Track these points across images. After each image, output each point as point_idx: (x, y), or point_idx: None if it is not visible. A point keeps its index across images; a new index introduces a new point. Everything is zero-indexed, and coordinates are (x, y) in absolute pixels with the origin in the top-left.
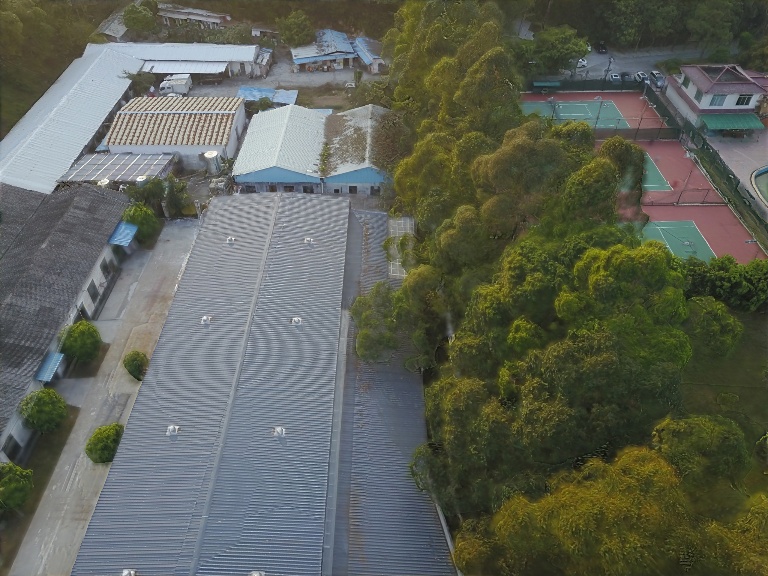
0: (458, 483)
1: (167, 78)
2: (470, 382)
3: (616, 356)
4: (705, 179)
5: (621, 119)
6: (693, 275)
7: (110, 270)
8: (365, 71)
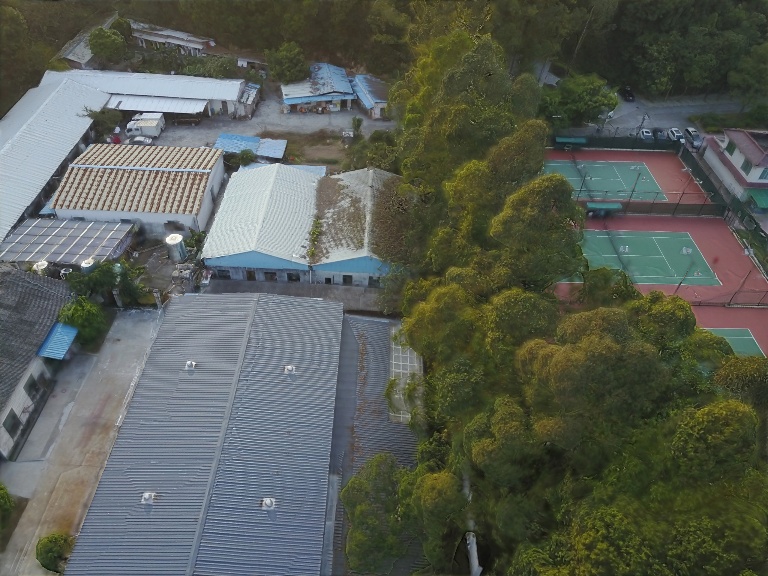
0: None
1: (136, 117)
2: None
3: None
4: (757, 271)
5: (660, 193)
6: None
7: (39, 386)
8: (365, 115)
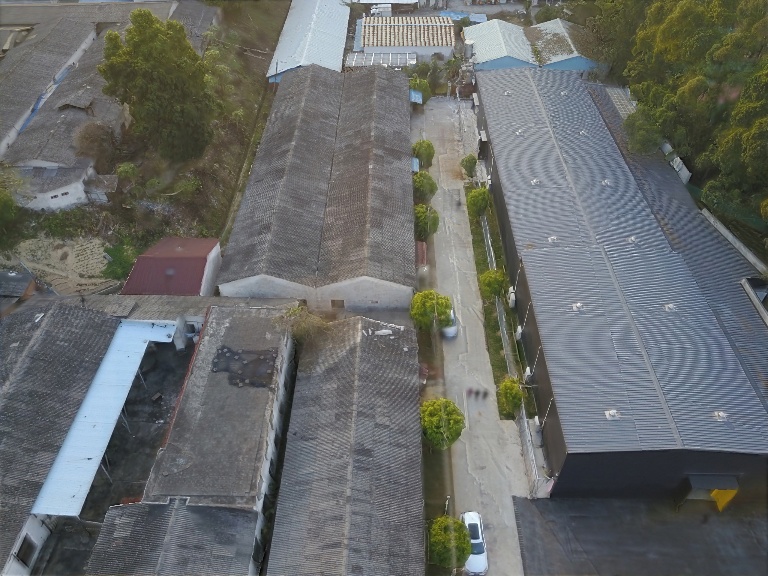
0: (739, 198)
1: (374, 7)
2: None
3: None
4: None
5: None
6: None
7: None
8: None
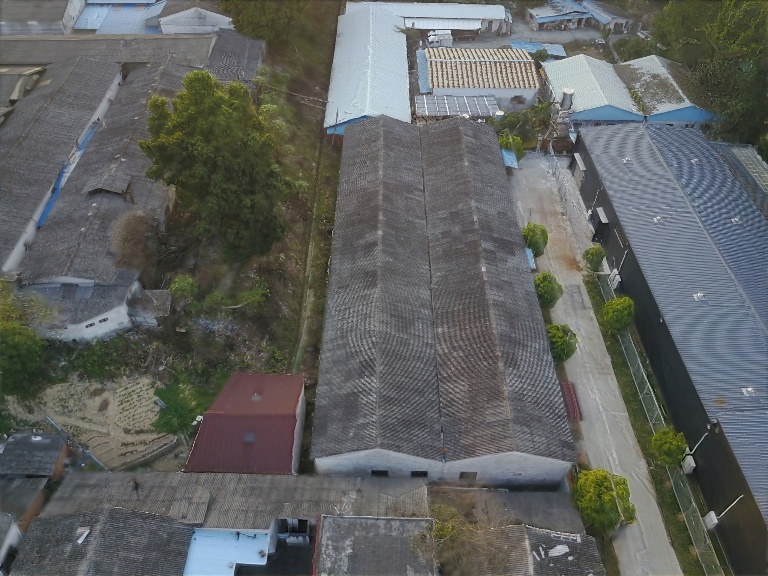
0: None
1: (432, 33)
2: None
3: None
4: None
5: None
6: None
7: None
8: (598, 30)
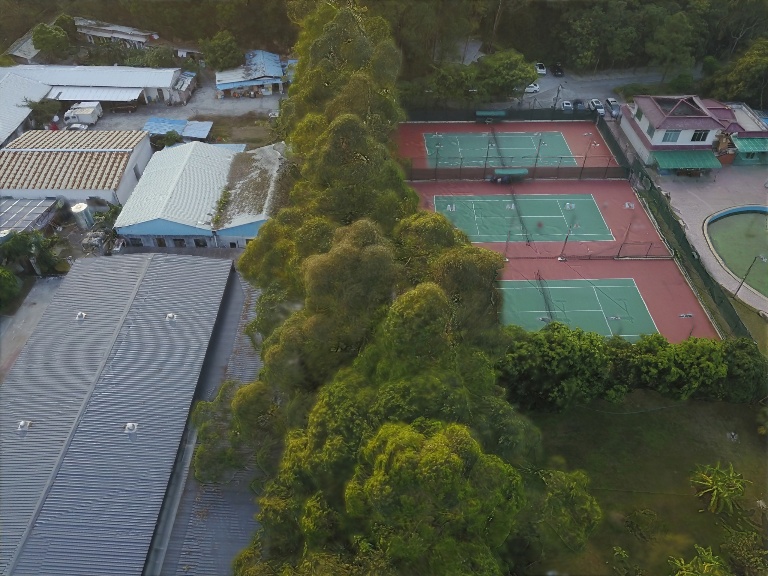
0: None
1: (74, 106)
2: (256, 573)
3: None
4: (652, 227)
5: (563, 157)
6: (614, 359)
7: None
8: None
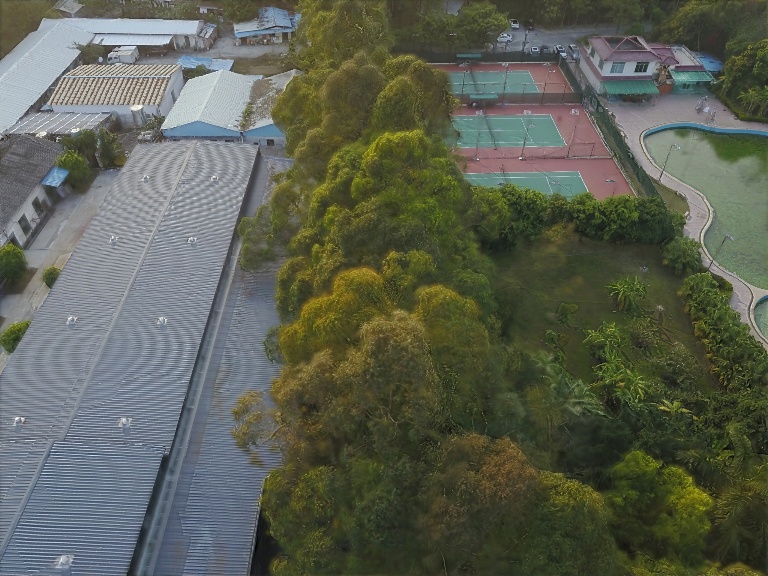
0: None
1: (115, 49)
2: None
3: (375, 215)
4: (598, 137)
5: (527, 84)
6: (552, 208)
7: (43, 209)
8: None
